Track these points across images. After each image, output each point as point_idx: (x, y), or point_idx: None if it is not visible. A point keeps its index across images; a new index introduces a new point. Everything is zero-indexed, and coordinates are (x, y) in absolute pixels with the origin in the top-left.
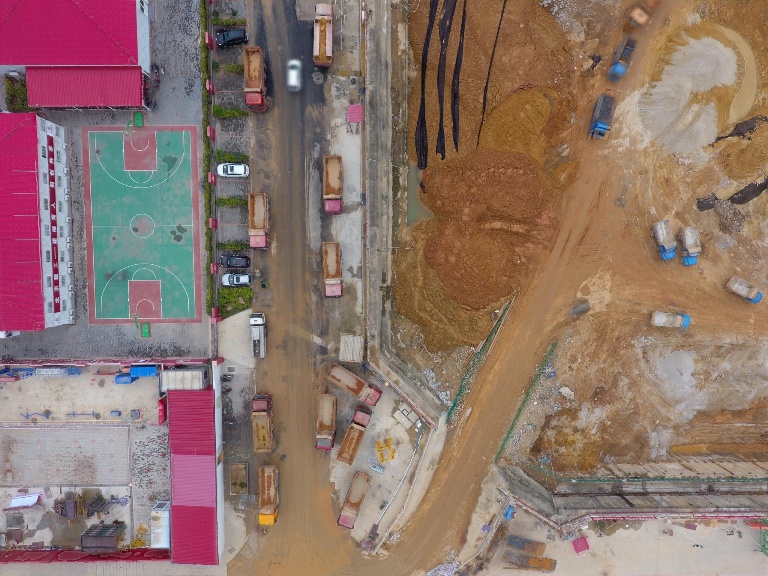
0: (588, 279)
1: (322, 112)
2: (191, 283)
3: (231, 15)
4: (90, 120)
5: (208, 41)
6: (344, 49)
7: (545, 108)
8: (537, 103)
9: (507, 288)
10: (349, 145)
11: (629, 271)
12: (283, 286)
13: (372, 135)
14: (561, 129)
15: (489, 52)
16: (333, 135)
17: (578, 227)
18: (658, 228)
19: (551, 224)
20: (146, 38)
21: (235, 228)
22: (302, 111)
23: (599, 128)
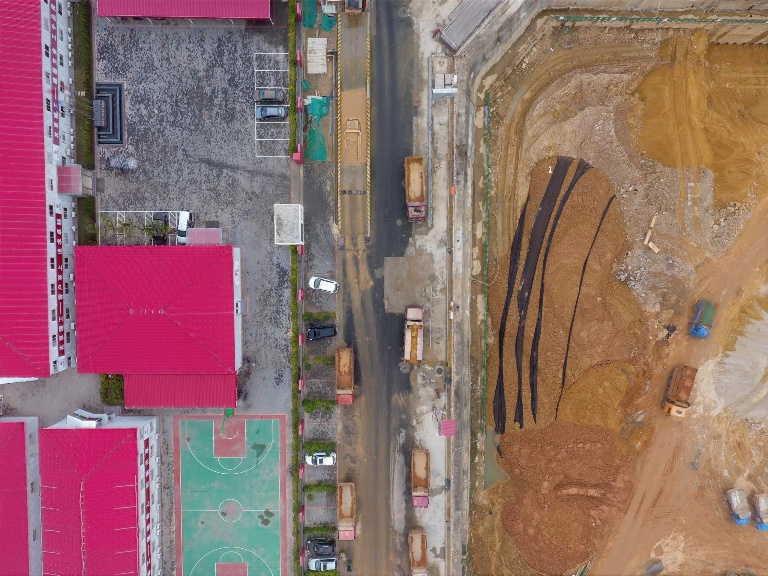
0: (661, 540)
1: (408, 399)
2: (277, 566)
3: (321, 308)
4: (181, 409)
5: (301, 343)
6: (431, 340)
7: (623, 384)
8: (615, 380)
9: (583, 554)
10: (434, 431)
11: (702, 532)
12: (367, 566)
13: (457, 423)
14: (636, 397)
15: (567, 325)
16: (418, 421)
17: (652, 489)
18: (732, 495)
19: (626, 487)
20: (239, 335)
21: (321, 511)
22: (389, 399)
23: (676, 406)
